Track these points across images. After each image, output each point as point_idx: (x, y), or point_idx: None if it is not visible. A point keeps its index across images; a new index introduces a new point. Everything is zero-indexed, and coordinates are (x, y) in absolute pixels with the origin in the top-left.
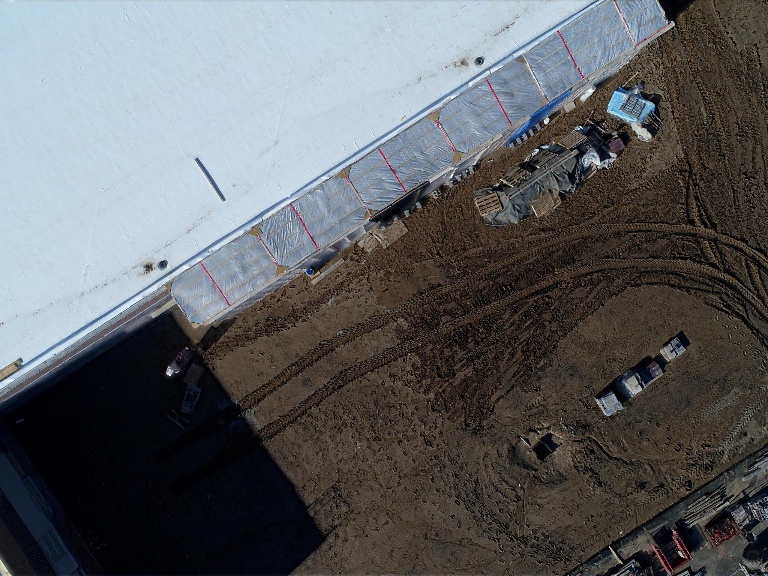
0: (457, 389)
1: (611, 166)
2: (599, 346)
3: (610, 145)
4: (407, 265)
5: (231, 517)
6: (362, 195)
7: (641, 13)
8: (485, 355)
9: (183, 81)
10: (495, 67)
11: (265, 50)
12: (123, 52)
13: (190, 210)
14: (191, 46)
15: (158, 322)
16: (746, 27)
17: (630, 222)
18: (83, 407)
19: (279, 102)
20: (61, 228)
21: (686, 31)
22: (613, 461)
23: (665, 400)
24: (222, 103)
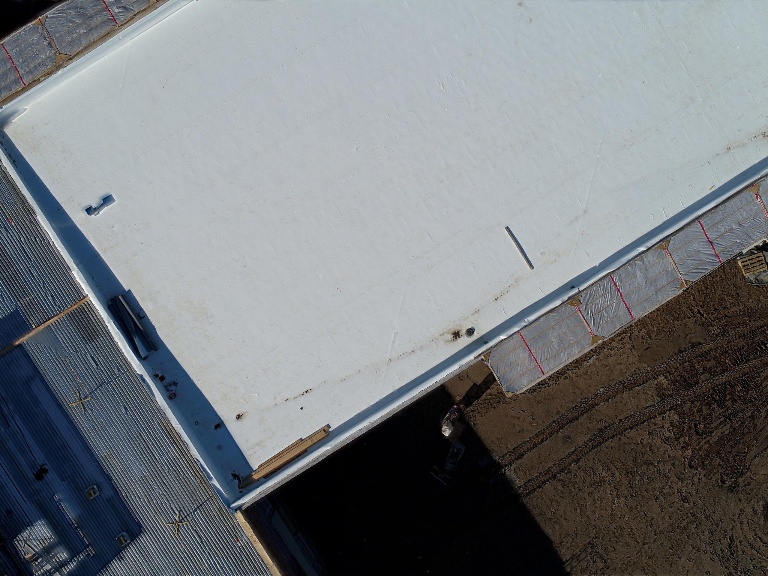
0: (714, 446)
1: None
2: None
3: None
4: (668, 323)
5: (489, 572)
6: (679, 266)
7: None
8: (742, 413)
9: (495, 150)
10: None
11: (577, 119)
12: (437, 121)
13: (498, 278)
14: (504, 115)
15: None
16: None
17: None
18: (345, 463)
19: (589, 171)
20: (371, 295)
21: None
22: None
23: None
24: (533, 172)
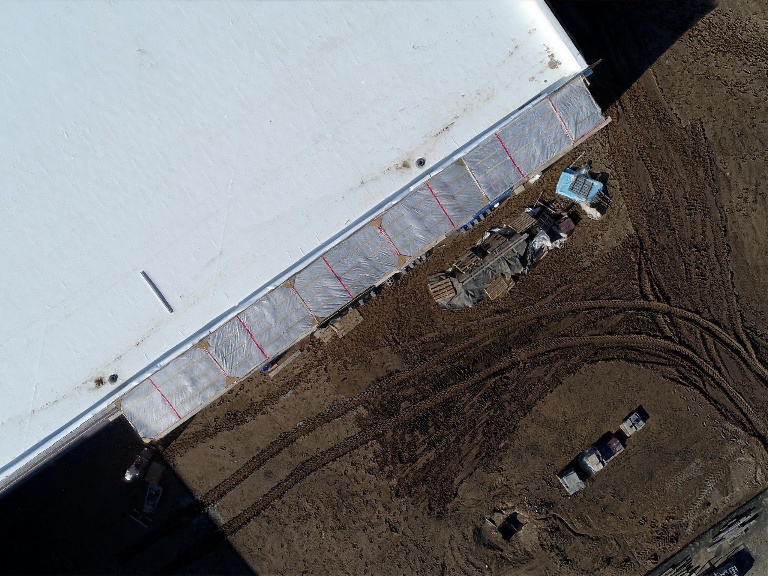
0: (420, 474)
1: (562, 245)
2: (559, 424)
3: (560, 226)
4: (364, 353)
5: None
6: (308, 303)
7: (577, 111)
8: (446, 438)
9: (125, 195)
10: (435, 171)
11: (206, 161)
12: (64, 169)
13: (138, 323)
14: (132, 160)
15: (117, 422)
16: (689, 102)
17: (584, 300)
18: (45, 511)
19: (222, 212)
20: (9, 347)
21: (630, 109)
22: (579, 538)
23: (627, 474)
24: (165, 215)
